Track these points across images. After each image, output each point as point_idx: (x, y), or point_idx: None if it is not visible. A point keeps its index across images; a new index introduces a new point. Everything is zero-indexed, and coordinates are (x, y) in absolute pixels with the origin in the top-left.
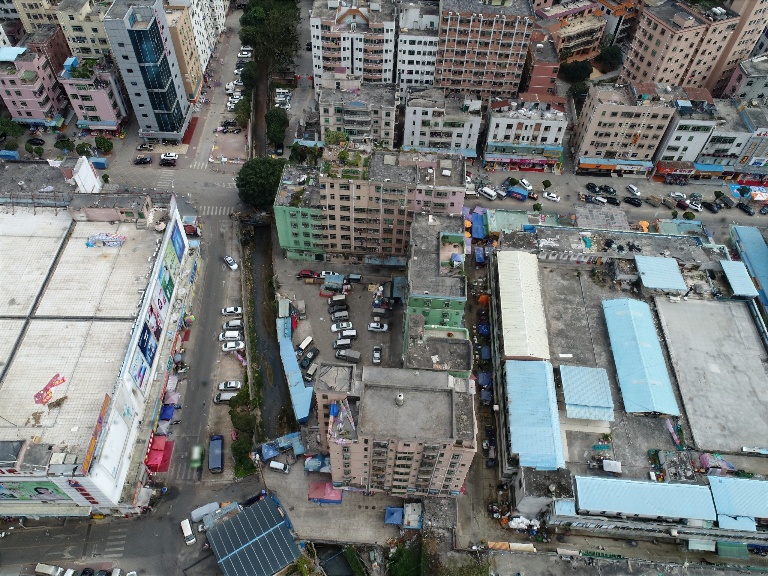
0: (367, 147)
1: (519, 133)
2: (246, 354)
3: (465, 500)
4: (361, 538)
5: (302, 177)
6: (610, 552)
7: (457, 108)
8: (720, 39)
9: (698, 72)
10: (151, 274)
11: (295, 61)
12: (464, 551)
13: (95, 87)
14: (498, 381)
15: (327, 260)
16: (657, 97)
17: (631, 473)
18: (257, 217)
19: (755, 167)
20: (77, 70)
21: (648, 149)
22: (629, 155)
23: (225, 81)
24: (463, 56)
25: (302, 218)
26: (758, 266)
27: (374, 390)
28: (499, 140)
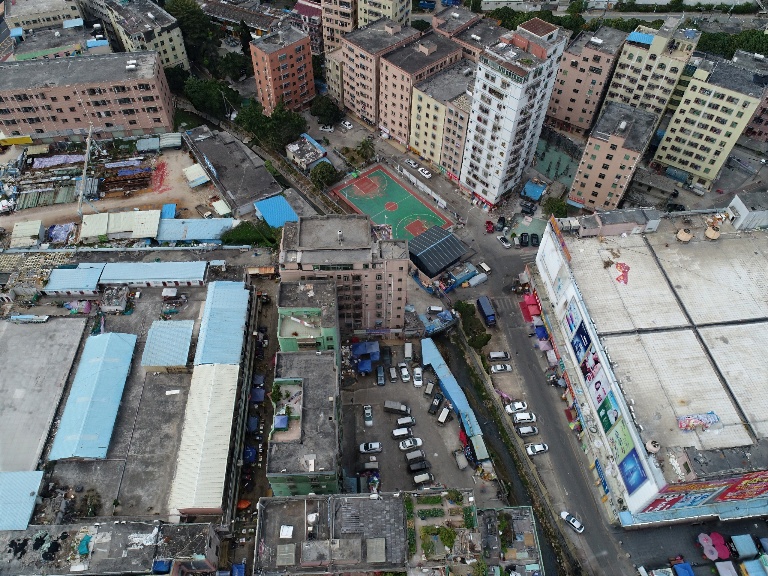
0: None
1: None
2: None
3: None
4: None
5: None
6: None
7: None
8: None
9: None
10: None
11: None
12: None
13: None
14: None
15: None
16: None
17: (154, 298)
18: None
19: None
20: None
21: None
22: None
23: None
24: None
25: None
26: None
27: None
28: None
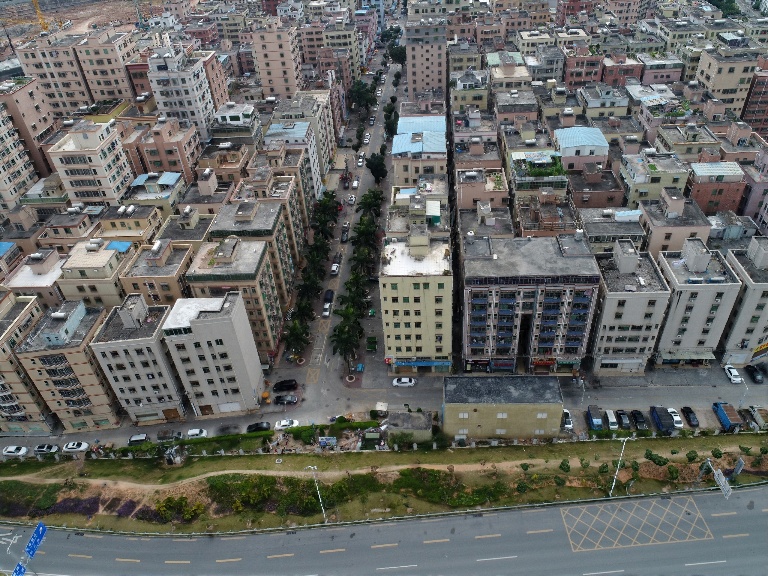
0: None
1: None
2: None
3: None
4: None
5: None
6: None
7: None
8: None
9: None
10: None
11: None
12: None
13: None
14: None
15: None
16: None
17: None
18: None
19: None
20: (372, 6)
21: None
22: None
23: None
24: None
25: None
26: None
27: None
28: None
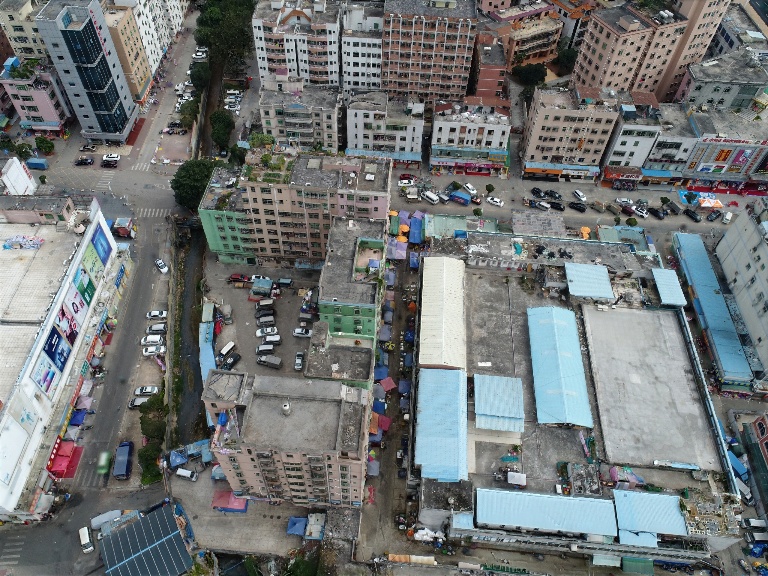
0: (293, 150)
1: (463, 137)
2: (165, 359)
3: (373, 510)
4: (262, 548)
5: (231, 180)
6: (515, 566)
7: (401, 111)
8: (669, 43)
9: (648, 76)
10: (64, 277)
11: (249, 62)
12: (362, 563)
13: (35, 87)
14: (412, 390)
15: (259, 264)
16: (601, 101)
17: (537, 486)
18: (193, 220)
19: (704, 173)
20: (16, 70)
21: (594, 154)
22: (576, 160)
23: (177, 82)
24: (408, 58)
25: (228, 222)
26: (696, 274)
27: (263, 399)
28: (443, 144)
